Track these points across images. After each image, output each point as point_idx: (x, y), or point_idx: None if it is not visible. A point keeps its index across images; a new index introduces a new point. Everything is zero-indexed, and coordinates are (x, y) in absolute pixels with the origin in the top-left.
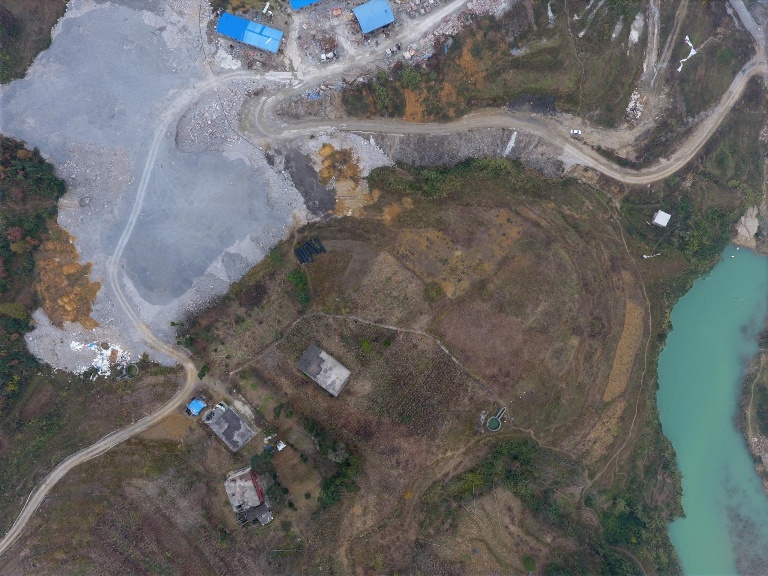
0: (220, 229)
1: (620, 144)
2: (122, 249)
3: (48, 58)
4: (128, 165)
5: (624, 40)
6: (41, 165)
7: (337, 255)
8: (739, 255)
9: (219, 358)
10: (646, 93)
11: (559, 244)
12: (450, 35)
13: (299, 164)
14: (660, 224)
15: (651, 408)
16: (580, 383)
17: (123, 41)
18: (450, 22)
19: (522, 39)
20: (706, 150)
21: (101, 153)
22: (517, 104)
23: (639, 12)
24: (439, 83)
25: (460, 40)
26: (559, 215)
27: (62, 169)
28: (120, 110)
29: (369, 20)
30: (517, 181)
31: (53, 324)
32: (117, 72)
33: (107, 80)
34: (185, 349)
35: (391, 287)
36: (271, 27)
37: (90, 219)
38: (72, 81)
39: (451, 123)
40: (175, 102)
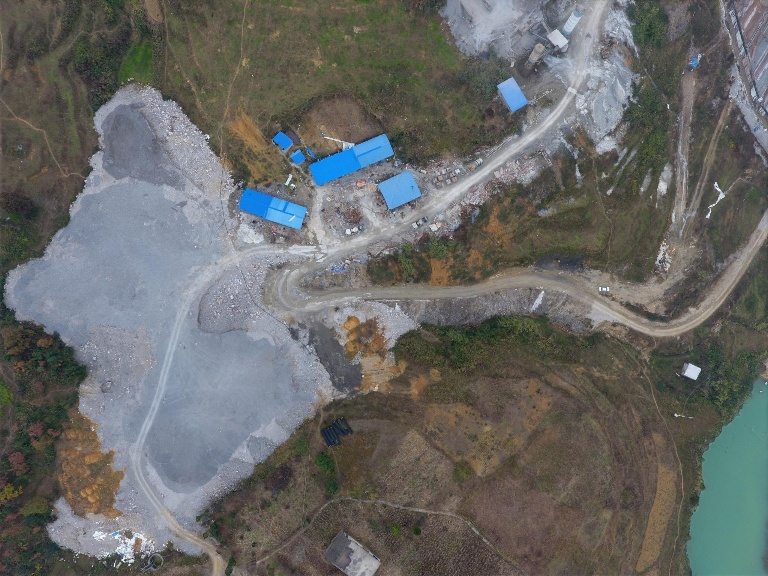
0: (245, 415)
1: (649, 299)
2: (145, 436)
3: (67, 237)
4: (150, 347)
5: (652, 193)
6: (61, 351)
7: (364, 436)
8: (767, 390)
9: (245, 546)
10: (675, 244)
11: (590, 414)
12: (477, 205)
13: (324, 338)
14: (690, 377)
15: (683, 568)
16: (613, 557)
17: (143, 218)
18: (477, 192)
19: (550, 201)
20: (735, 296)
21: (122, 335)
22: (544, 262)
23: (667, 163)
24: (466, 251)
25: (487, 208)
26: (589, 380)
27: (82, 350)
28: (141, 290)
29: (395, 197)
30: (546, 346)
31: (75, 514)
32: (137, 250)
33: (127, 259)
34: (210, 537)
35: (420, 468)
36: (294, 200)
37: (112, 405)
38: (92, 261)
39: (477, 285)
40: (197, 280)
